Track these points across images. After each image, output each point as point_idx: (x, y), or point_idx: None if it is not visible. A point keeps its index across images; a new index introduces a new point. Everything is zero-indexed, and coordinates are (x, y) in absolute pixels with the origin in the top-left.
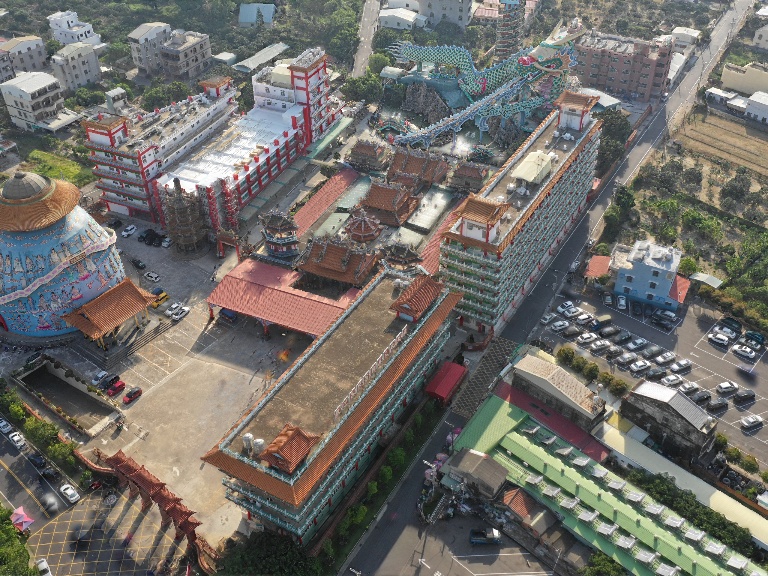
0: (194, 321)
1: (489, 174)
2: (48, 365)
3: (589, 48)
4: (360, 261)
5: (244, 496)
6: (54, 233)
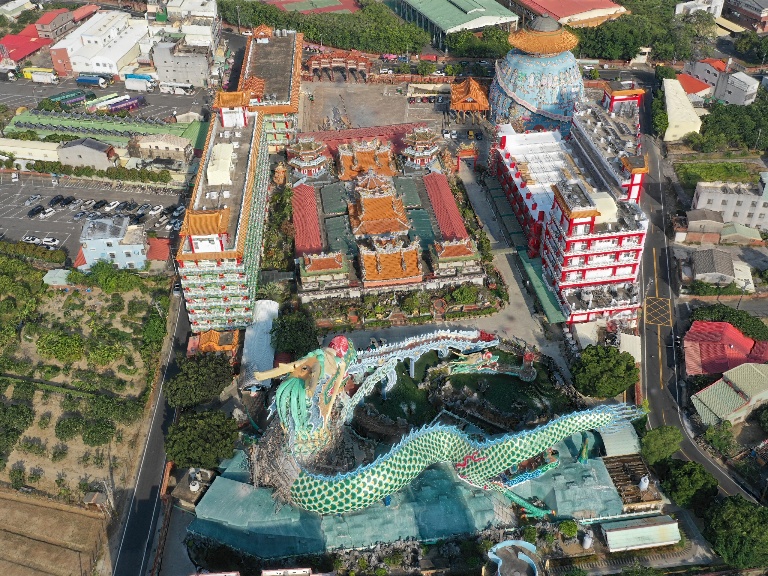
0: None
1: (305, 270)
2: None
3: (291, 569)
4: None
5: None
6: None
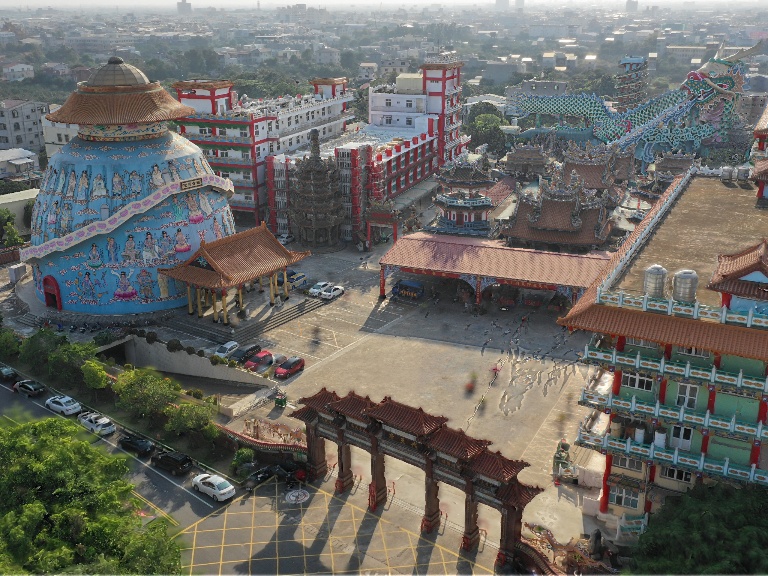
0: (355, 300)
1: None
2: (130, 348)
3: None
4: (598, 216)
5: (619, 434)
6: (157, 147)
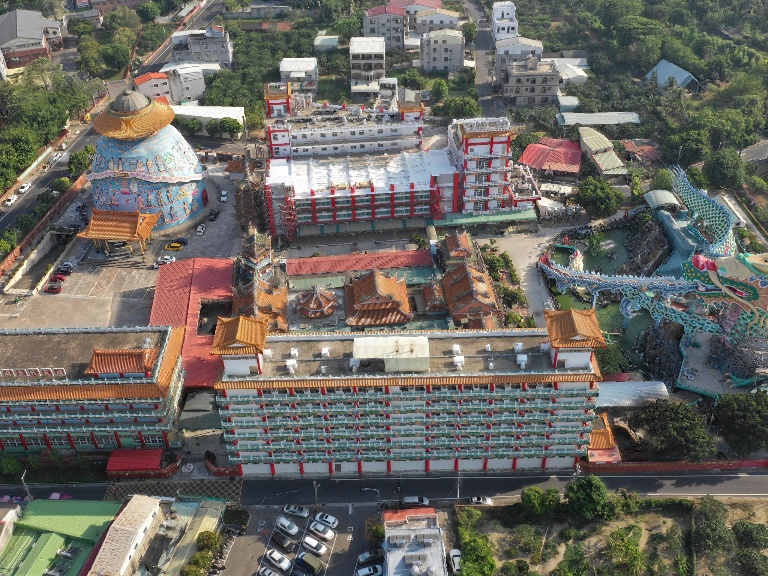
0: None
1: None
2: None
3: None
4: None
5: None
6: (123, 147)
